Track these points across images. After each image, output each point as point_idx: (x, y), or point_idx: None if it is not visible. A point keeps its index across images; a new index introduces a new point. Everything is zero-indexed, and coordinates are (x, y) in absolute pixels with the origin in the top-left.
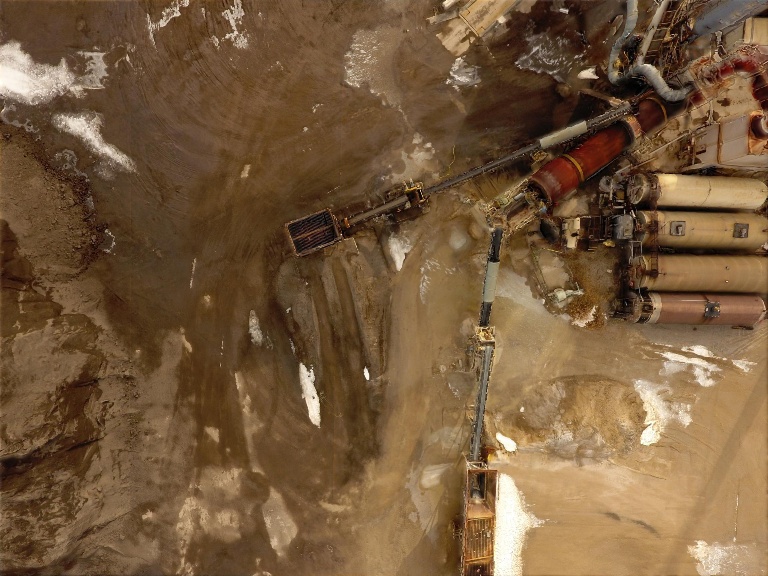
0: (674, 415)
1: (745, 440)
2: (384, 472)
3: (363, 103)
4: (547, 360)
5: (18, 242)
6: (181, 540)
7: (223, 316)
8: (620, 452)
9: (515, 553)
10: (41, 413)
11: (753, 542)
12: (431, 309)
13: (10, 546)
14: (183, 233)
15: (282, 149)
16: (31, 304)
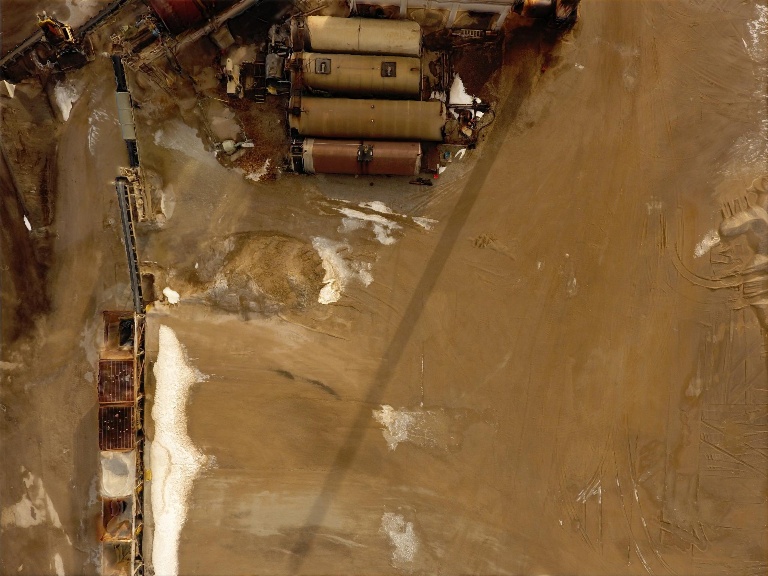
0: (354, 274)
1: (428, 301)
2: (56, 329)
3: None
4: (221, 215)
5: None
6: None
7: None
8: (293, 309)
9: (178, 408)
10: None
11: (441, 407)
12: (100, 161)
13: None
14: None
15: None
16: None
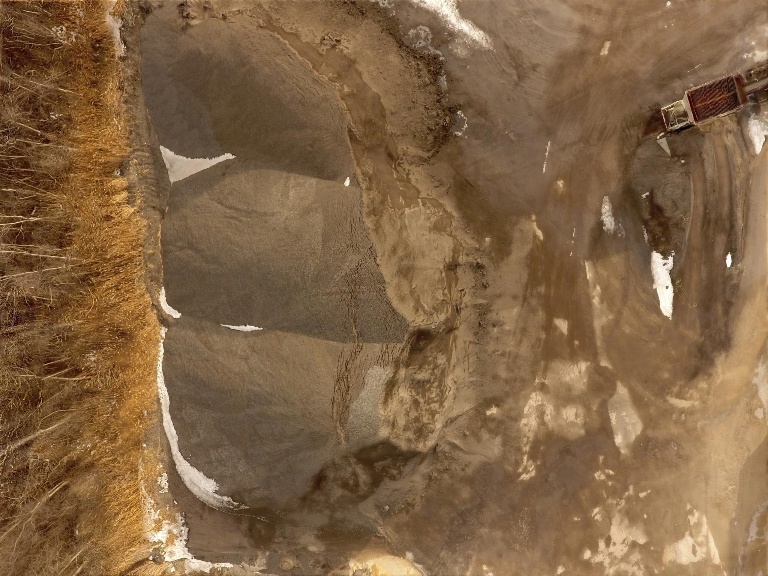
0: None
1: None
2: (733, 366)
3: None
4: None
5: (386, 118)
6: (524, 437)
7: (576, 202)
8: None
9: None
10: (439, 288)
11: None
12: None
13: (412, 425)
14: (538, 114)
15: (644, 25)
16: (402, 183)
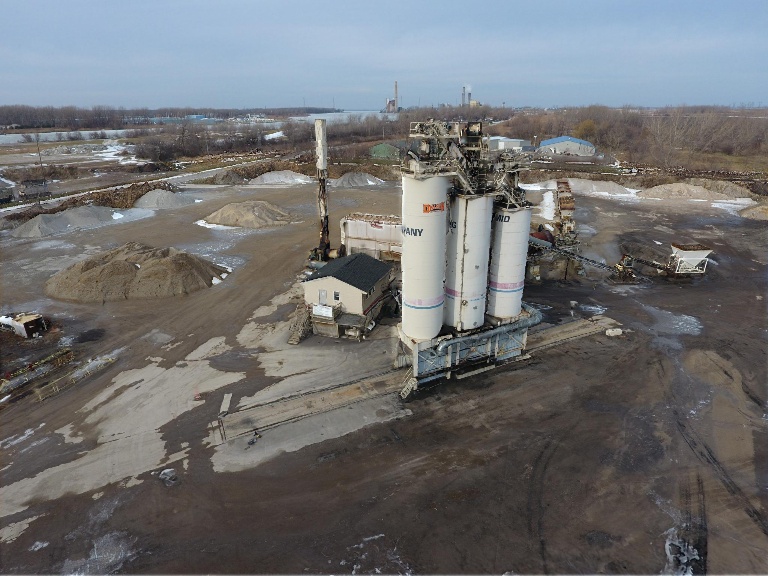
0: None
1: None
2: None
3: (675, 309)
4: None
5: None
6: None
7: None
8: None
9: None
10: None
11: None
12: None
13: None
14: None
15: None
16: None
